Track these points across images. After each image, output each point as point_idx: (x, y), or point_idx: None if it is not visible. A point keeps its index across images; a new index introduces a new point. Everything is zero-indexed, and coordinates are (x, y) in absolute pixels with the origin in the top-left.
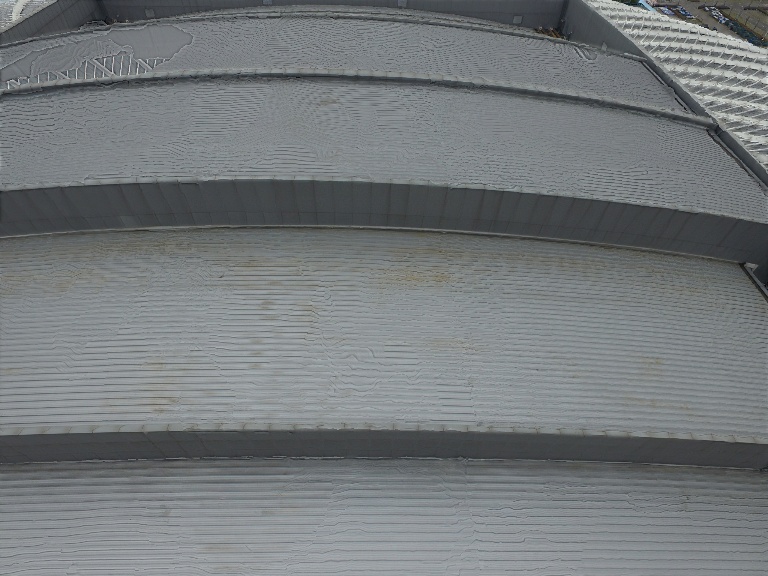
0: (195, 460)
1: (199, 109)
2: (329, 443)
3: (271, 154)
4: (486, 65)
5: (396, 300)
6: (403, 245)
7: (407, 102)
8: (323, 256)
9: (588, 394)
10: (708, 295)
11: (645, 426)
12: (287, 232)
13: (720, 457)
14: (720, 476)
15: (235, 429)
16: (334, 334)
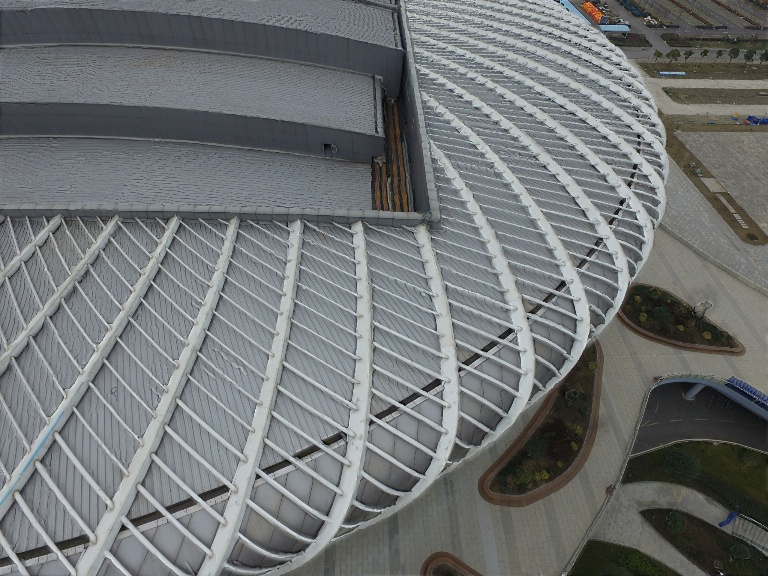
0: (10, 139)
1: None
2: (71, 118)
3: None
4: None
5: None
6: (153, 54)
7: None
8: (101, 56)
9: (213, 102)
10: (332, 83)
11: (236, 112)
12: (85, 47)
13: (290, 140)
14: (302, 158)
15: (18, 102)
16: None
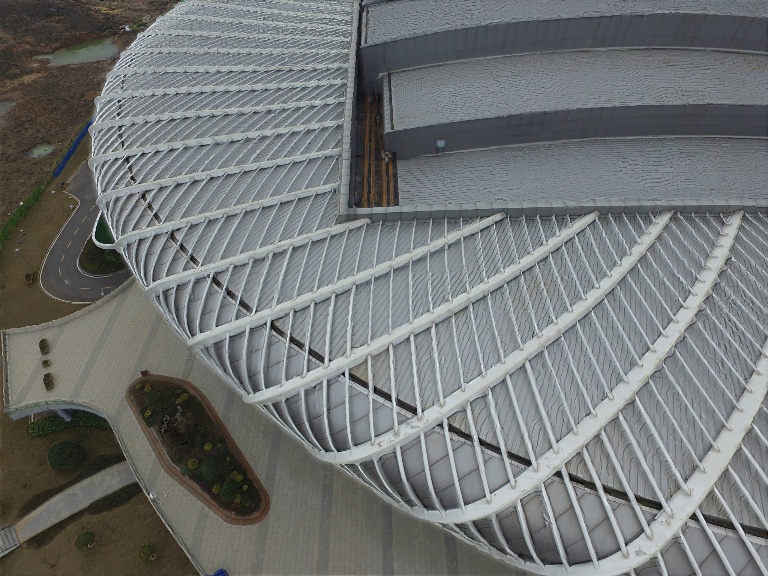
0: None
1: None
2: (760, 120)
3: (680, 1)
4: None
5: None
6: None
7: None
8: (702, 59)
9: None
10: None
11: None
12: None
13: None
14: None
15: (728, 104)
16: None
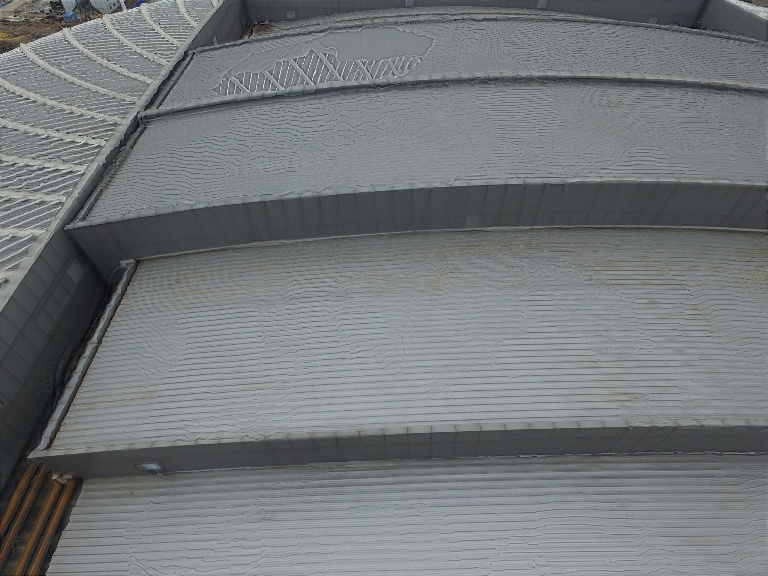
0: (620, 455)
1: (490, 111)
2: None
3: (632, 156)
4: (722, 67)
5: (767, 299)
6: (736, 245)
7: (689, 104)
8: (673, 256)
9: None
10: None
11: None
12: (622, 232)
13: None
14: None
15: (716, 425)
16: (728, 332)
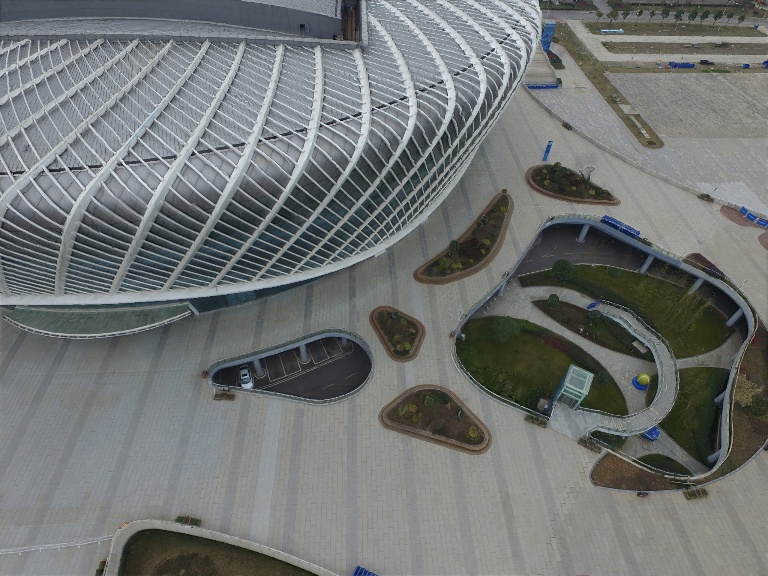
0: (87, 20)
1: None
2: (130, 3)
3: None
4: None
5: None
6: None
7: None
8: None
9: None
10: None
11: None
12: None
13: (277, 21)
14: None
15: None
16: None
